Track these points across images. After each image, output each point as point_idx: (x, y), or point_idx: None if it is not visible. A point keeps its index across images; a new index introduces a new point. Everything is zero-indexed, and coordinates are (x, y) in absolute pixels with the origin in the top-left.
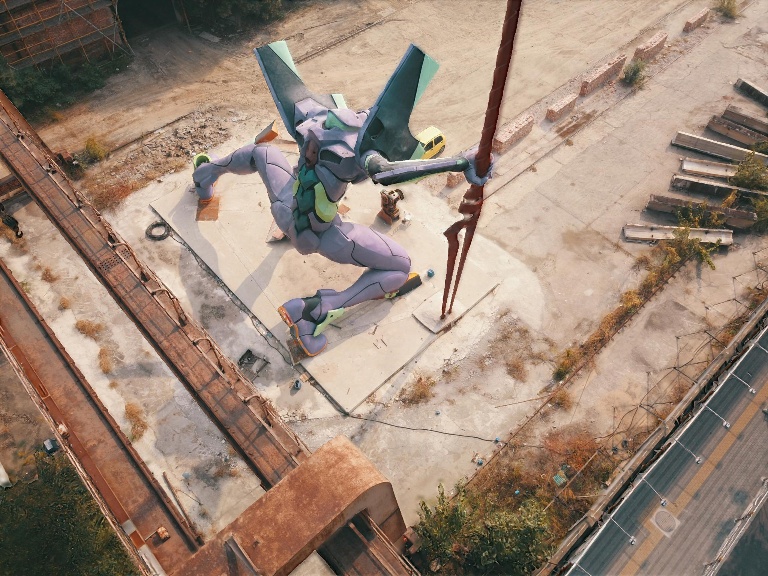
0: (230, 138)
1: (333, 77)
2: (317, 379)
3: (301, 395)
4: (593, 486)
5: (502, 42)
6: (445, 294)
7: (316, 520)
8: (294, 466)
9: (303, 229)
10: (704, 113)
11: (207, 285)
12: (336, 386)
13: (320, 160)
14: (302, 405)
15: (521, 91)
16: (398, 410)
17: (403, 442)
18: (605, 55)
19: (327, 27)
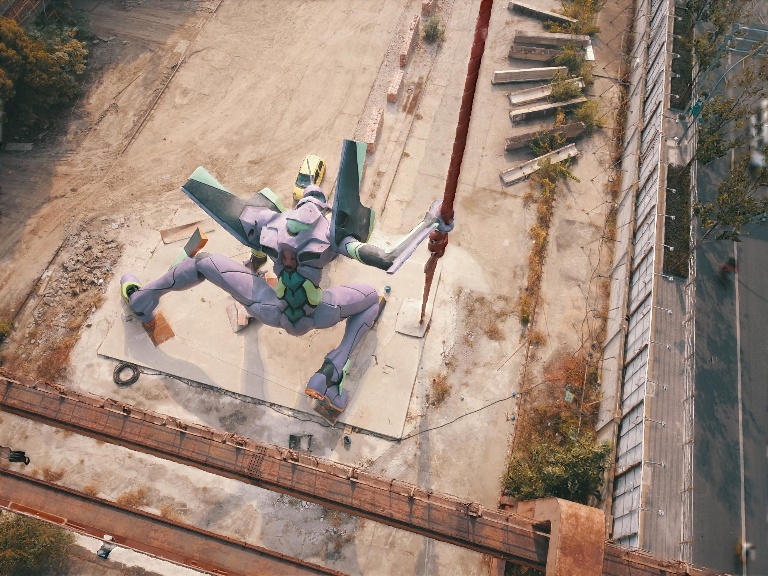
0: (124, 248)
1: (179, 139)
2: (359, 426)
3: (355, 446)
4: (592, 390)
5: (459, 138)
6: (423, 307)
7: (595, 565)
8: (511, 531)
9: (298, 319)
10: (500, 44)
11: (210, 399)
12: (378, 423)
13: (300, 262)
14: (361, 453)
15: (352, 83)
16: (433, 414)
17: (453, 436)
18: (398, 18)
19: (134, 86)
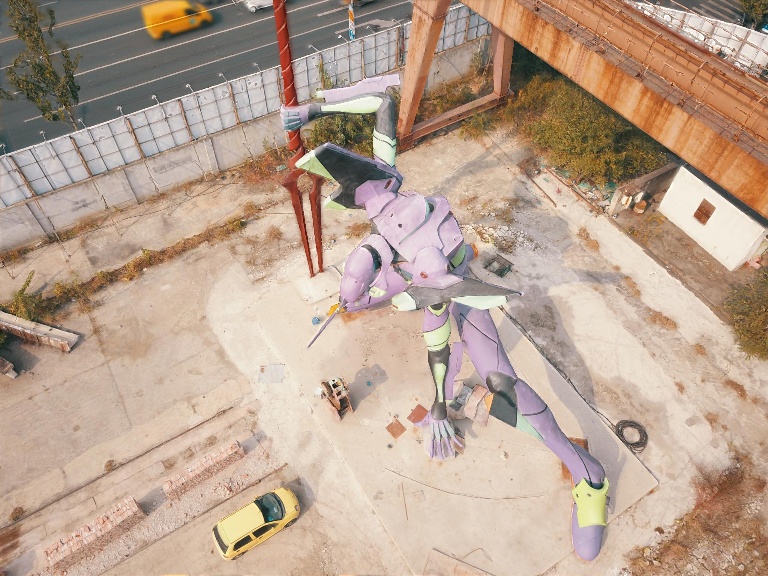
0: None
1: None
2: None
3: None
4: None
5: None
6: (321, 245)
7: None
8: None
9: None
10: None
11: (554, 351)
12: None
13: None
14: None
15: None
16: None
17: None
18: None
19: None
